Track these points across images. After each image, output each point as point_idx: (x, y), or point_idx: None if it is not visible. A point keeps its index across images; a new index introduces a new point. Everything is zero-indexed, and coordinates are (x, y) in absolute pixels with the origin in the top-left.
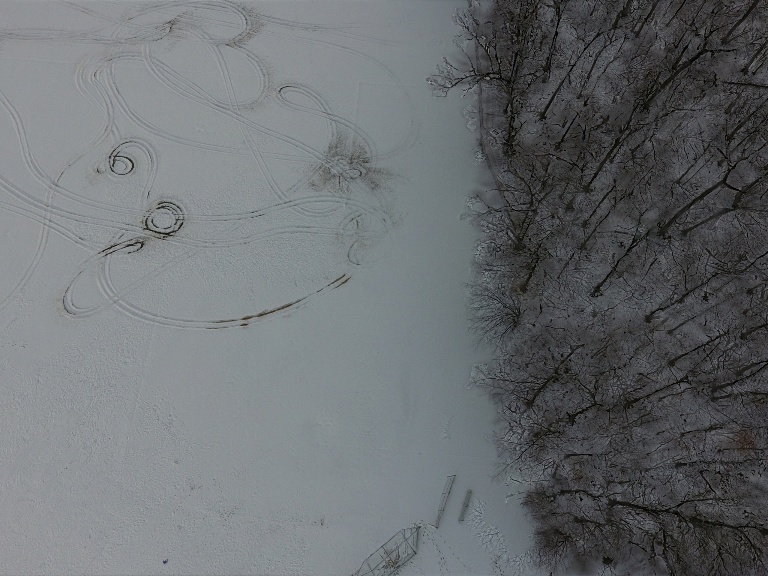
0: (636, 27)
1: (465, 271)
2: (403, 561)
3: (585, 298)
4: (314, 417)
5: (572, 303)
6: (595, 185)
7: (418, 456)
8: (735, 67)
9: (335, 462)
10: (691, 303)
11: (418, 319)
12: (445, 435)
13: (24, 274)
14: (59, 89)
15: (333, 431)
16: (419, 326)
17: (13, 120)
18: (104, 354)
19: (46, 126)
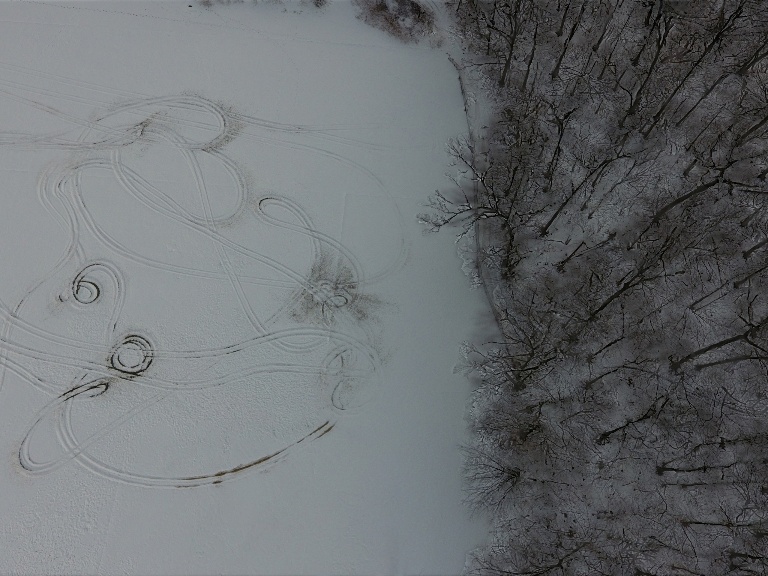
0: (644, 128)
1: (459, 417)
2: None
3: (591, 447)
4: None
5: (576, 454)
6: (601, 312)
7: None
8: (751, 172)
9: None
10: (706, 451)
11: (408, 475)
12: None
13: None
14: (20, 202)
15: None
16: (409, 484)
17: None
18: (62, 518)
19: (5, 246)
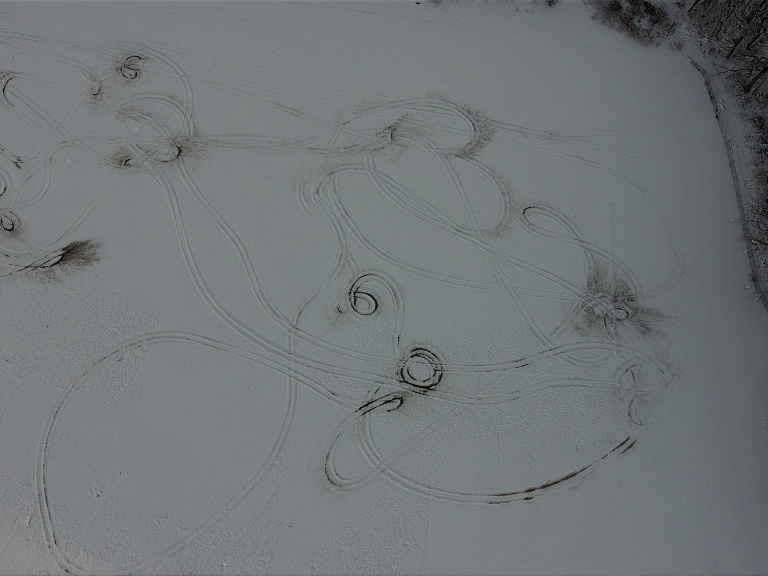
0: None
1: (759, 433)
2: None
3: None
4: None
5: None
6: None
7: None
8: None
9: None
10: None
11: (717, 492)
12: None
13: (277, 437)
14: (281, 209)
15: None
16: (719, 500)
17: (236, 248)
18: (380, 535)
19: (273, 255)
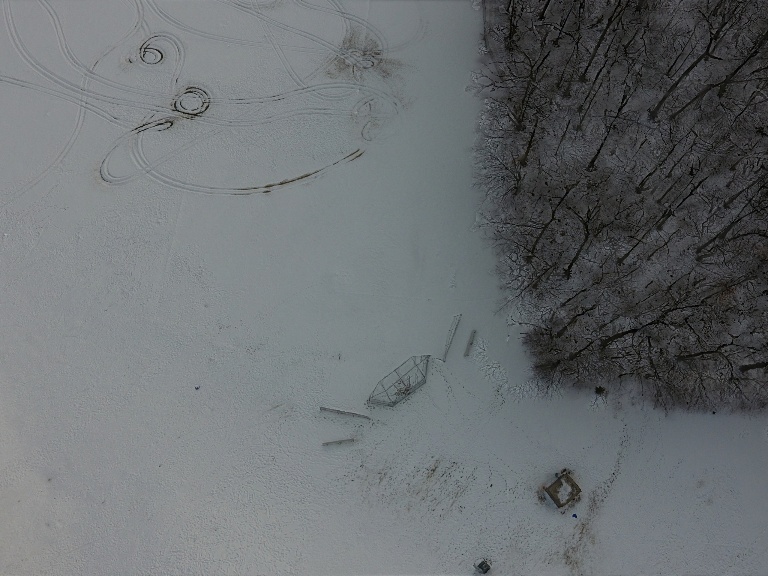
0: None
1: None
2: (413, 389)
3: (580, 172)
4: (332, 269)
5: (568, 175)
6: (590, 76)
7: (427, 302)
8: None
9: (351, 307)
10: (678, 177)
11: (426, 187)
12: (451, 284)
13: (63, 148)
14: None
15: (349, 281)
16: (427, 193)
17: (50, 17)
18: (138, 216)
19: (81, 22)
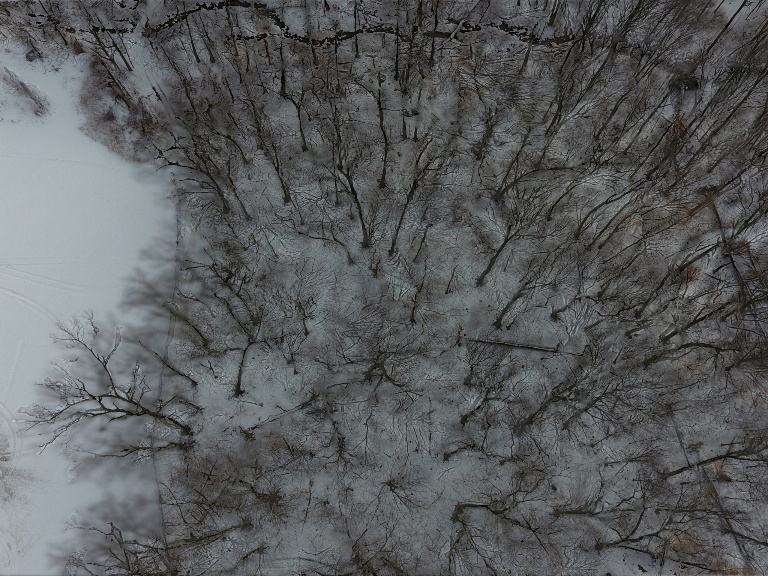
0: (372, 266)
1: None
2: None
3: None
4: None
5: None
6: (285, 490)
7: None
8: (487, 319)
9: None
10: None
11: None
12: None
13: None
14: None
15: None
16: None
17: None
18: None
19: None
